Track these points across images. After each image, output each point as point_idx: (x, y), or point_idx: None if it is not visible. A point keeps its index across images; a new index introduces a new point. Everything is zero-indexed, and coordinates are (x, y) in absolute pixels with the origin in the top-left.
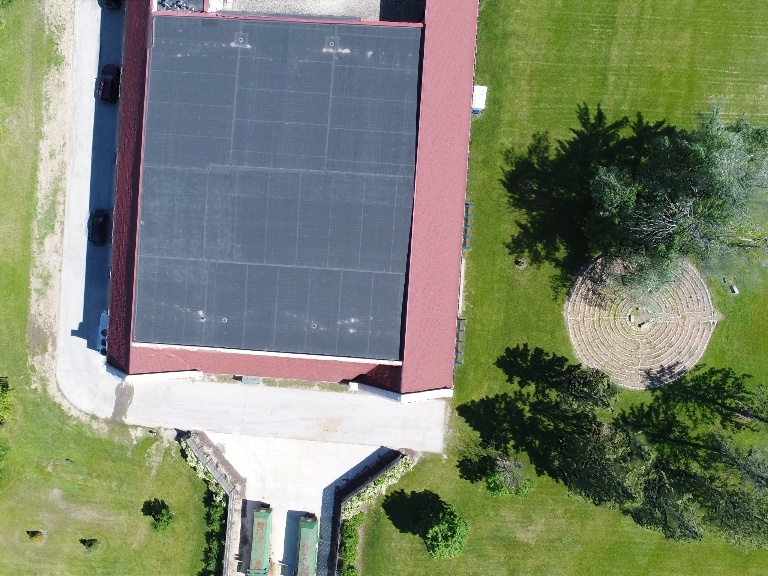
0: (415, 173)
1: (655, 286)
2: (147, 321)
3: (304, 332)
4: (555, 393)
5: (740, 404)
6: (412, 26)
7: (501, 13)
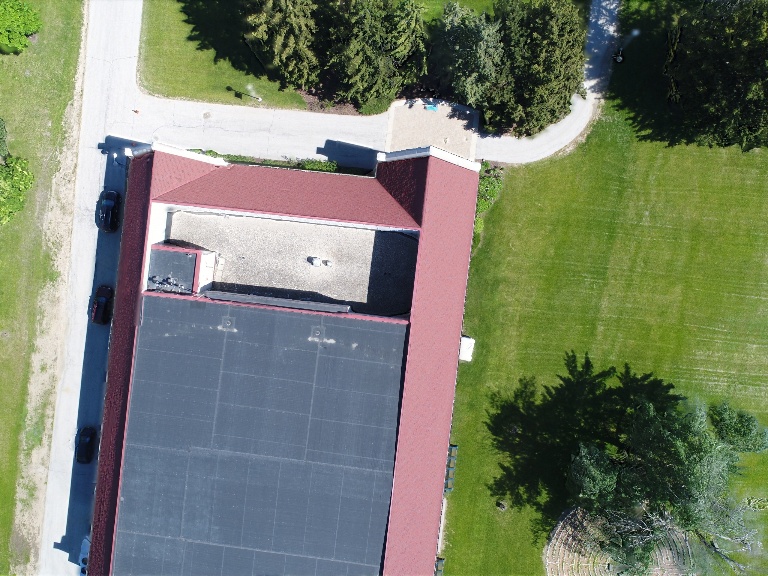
0: (394, 470)
1: None
2: None
3: None
4: None
5: None
6: (397, 323)
7: (493, 260)
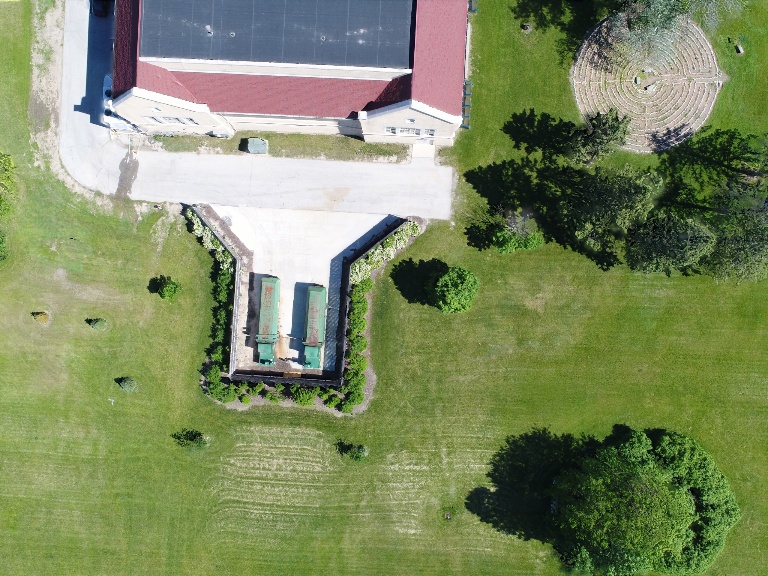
0: None
1: (662, 24)
2: (154, 37)
3: (313, 44)
4: (562, 159)
5: (746, 165)
6: None
7: None
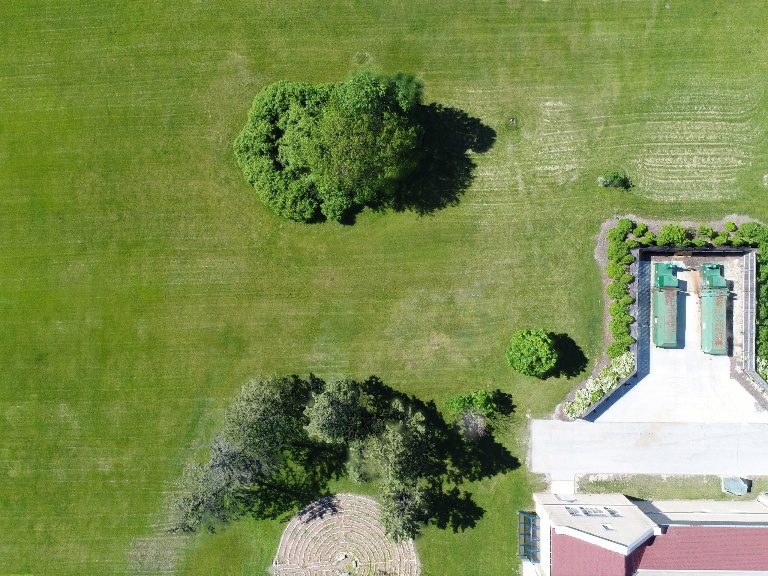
0: None
1: None
2: None
3: None
4: (423, 485)
5: (245, 486)
6: None
7: None
